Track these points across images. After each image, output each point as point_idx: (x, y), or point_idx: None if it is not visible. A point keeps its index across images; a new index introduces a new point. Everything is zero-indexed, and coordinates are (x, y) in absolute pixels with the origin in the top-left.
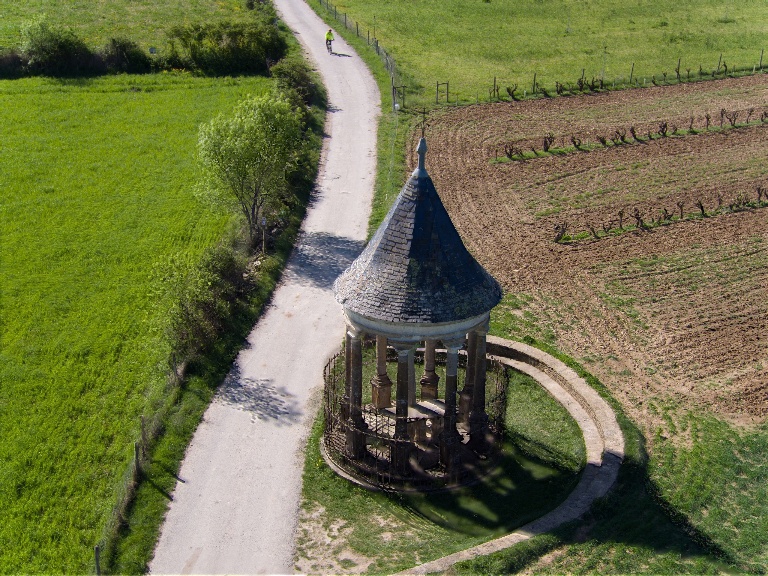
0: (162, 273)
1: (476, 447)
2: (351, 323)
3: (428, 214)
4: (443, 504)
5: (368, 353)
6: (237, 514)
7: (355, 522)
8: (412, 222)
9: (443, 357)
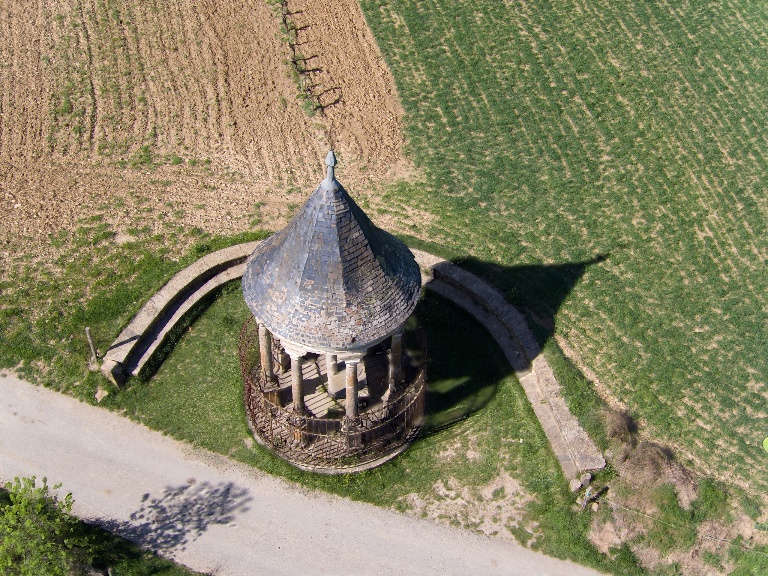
0: (0, 531)
1: (375, 350)
2: (352, 353)
3: (359, 211)
4: (440, 402)
5: (129, 388)
6: (401, 569)
7: (444, 474)
8: (359, 229)
9: (180, 326)
